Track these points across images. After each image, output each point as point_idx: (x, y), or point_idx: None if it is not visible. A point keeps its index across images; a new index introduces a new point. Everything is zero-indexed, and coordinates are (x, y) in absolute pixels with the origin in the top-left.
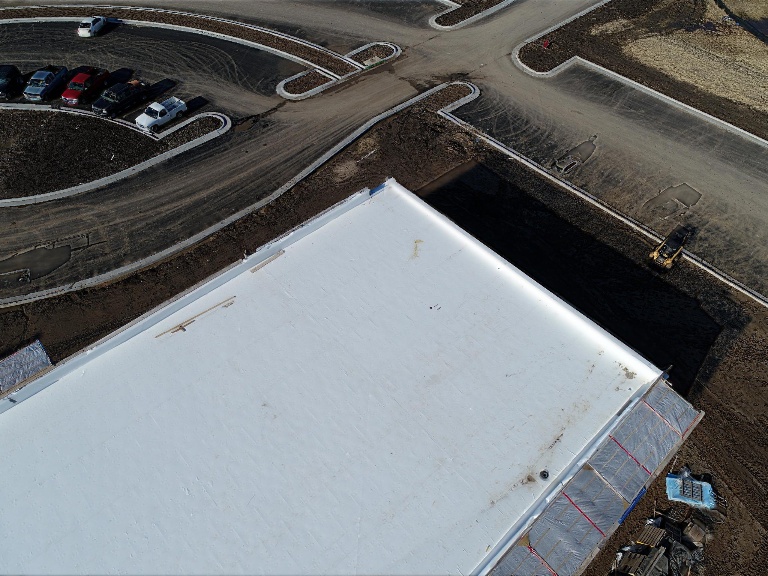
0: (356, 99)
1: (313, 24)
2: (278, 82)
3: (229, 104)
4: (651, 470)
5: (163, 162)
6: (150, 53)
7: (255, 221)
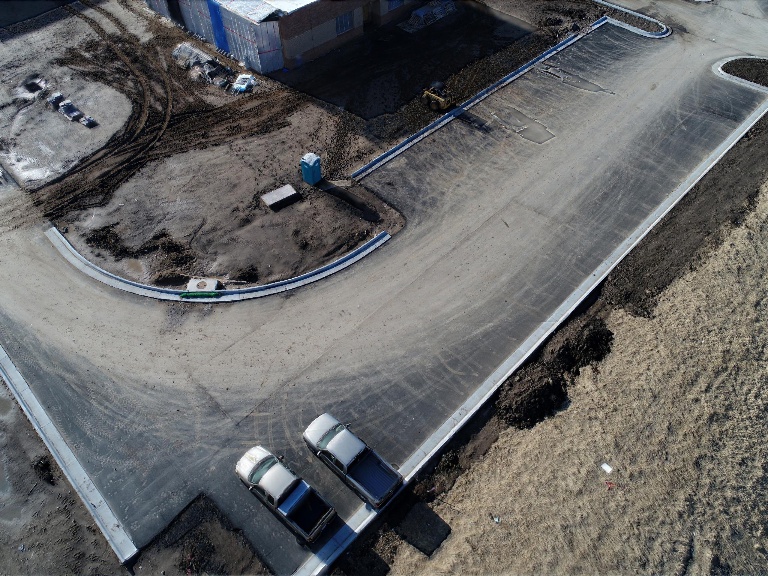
0: None
1: None
2: None
3: None
4: (228, 5)
5: None
6: None
7: None
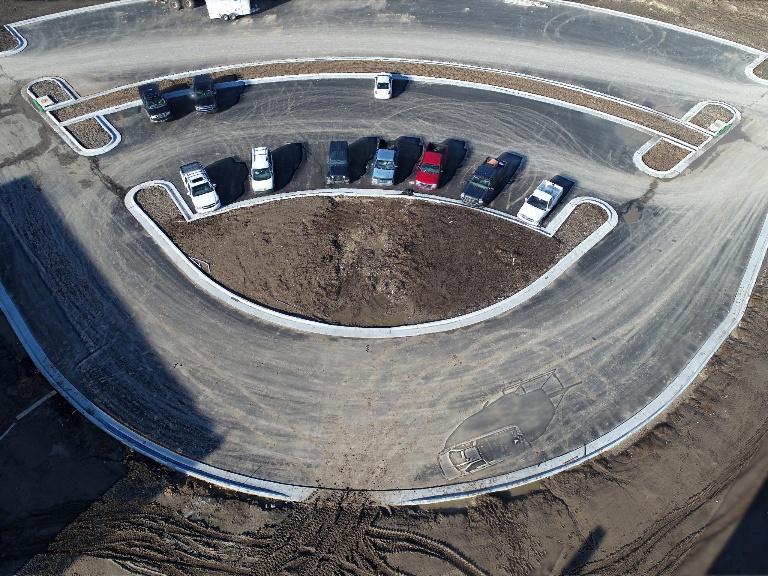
0: (734, 176)
1: (620, 79)
2: (631, 155)
3: (596, 185)
4: None
5: (573, 266)
6: (465, 118)
7: (741, 351)
